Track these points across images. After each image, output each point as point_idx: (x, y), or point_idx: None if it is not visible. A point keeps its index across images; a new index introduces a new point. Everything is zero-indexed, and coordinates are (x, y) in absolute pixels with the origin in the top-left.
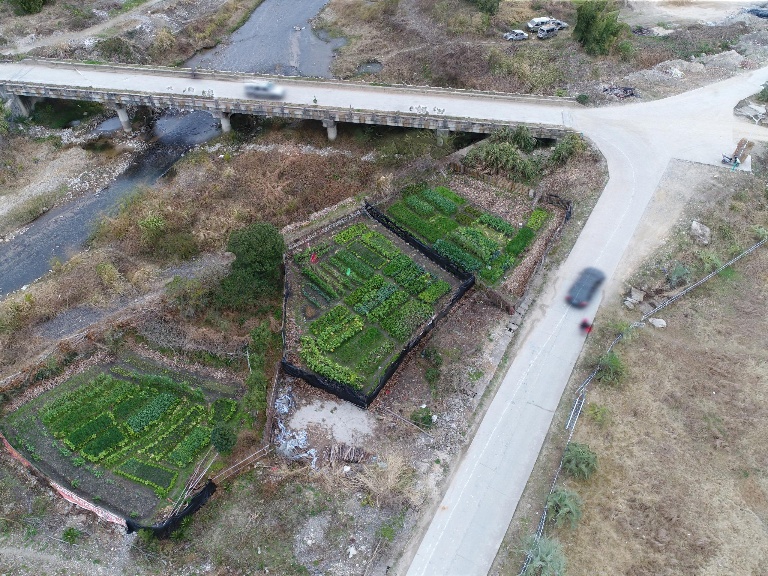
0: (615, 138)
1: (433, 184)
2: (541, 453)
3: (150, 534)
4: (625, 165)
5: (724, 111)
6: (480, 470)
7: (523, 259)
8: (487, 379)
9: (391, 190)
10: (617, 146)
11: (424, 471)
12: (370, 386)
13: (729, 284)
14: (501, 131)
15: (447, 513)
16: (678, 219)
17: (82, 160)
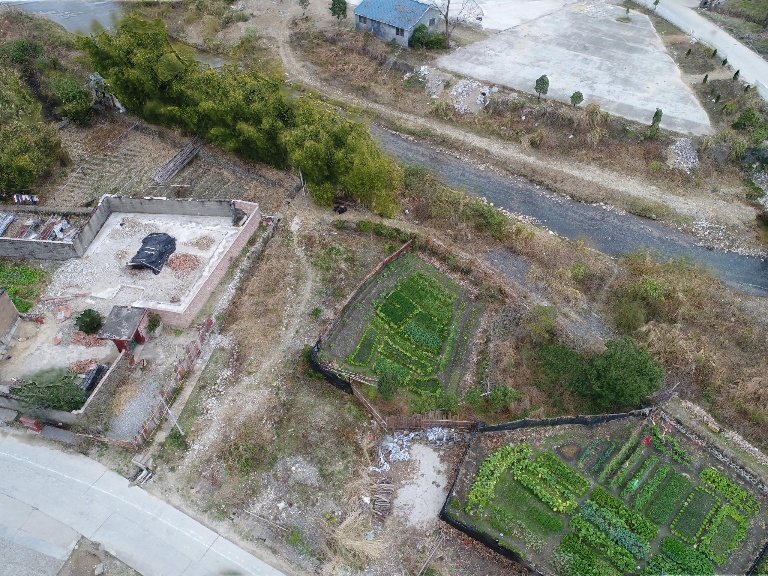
0: None
1: None
2: None
3: (308, 353)
4: None
5: None
6: None
7: None
8: None
9: None
10: None
11: None
12: (473, 523)
13: None
14: None
15: None
16: None
17: (739, 220)
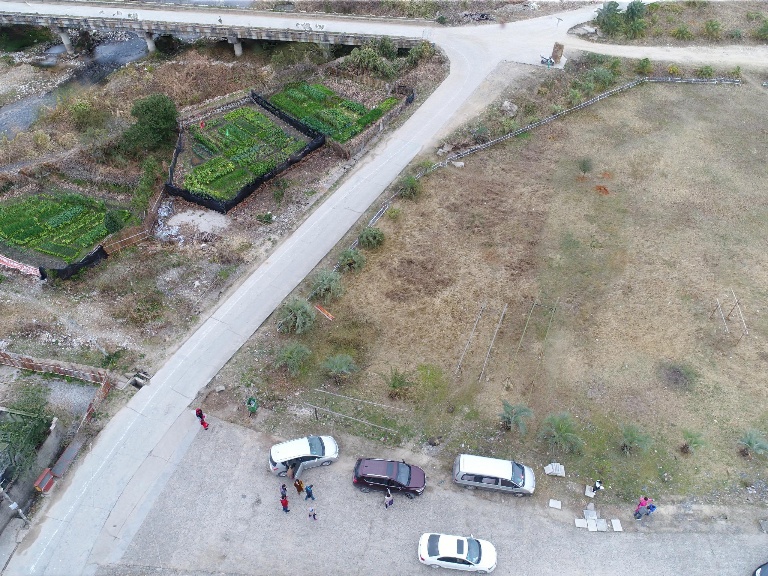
0: (461, 47)
1: (312, 82)
2: (346, 235)
3: (55, 274)
4: (464, 65)
5: (560, 30)
6: (299, 243)
7: (368, 128)
8: (318, 196)
9: (275, 84)
10: (461, 52)
11: (258, 244)
12: None
13: (522, 142)
14: (370, 42)
15: (269, 265)
16: (494, 100)
17: (30, 73)
